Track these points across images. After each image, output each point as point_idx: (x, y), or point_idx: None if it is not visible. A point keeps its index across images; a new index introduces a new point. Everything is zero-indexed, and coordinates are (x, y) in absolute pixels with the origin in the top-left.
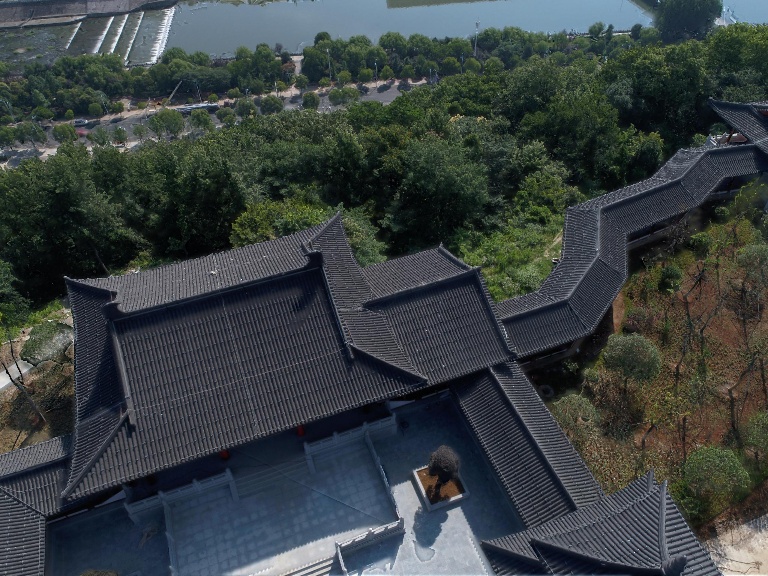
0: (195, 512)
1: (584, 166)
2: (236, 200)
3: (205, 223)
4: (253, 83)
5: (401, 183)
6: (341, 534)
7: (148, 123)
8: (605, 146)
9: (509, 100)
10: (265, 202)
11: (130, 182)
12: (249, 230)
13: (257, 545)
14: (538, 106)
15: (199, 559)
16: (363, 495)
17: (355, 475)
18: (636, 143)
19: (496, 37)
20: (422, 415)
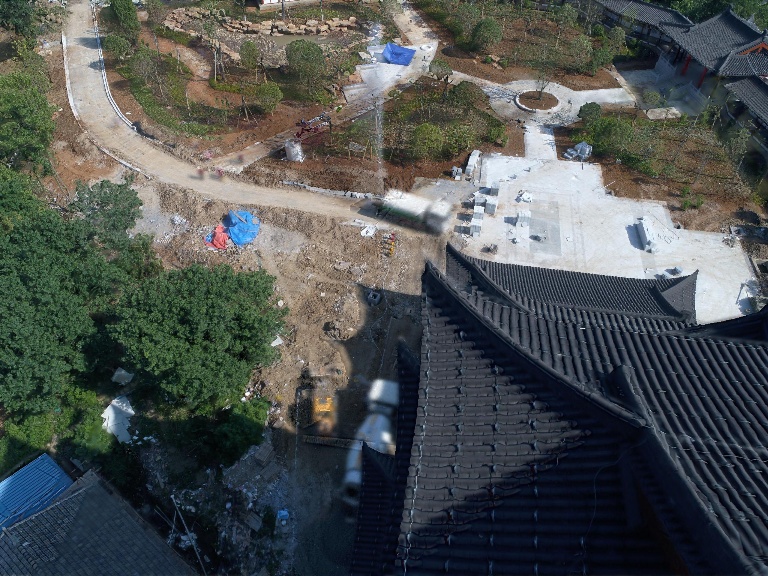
0: None
1: None
2: None
3: None
4: None
5: None
6: None
7: None
8: None
9: None
10: None
11: None
12: None
13: None
14: None
15: None
16: None
17: None
18: None
19: None
20: None
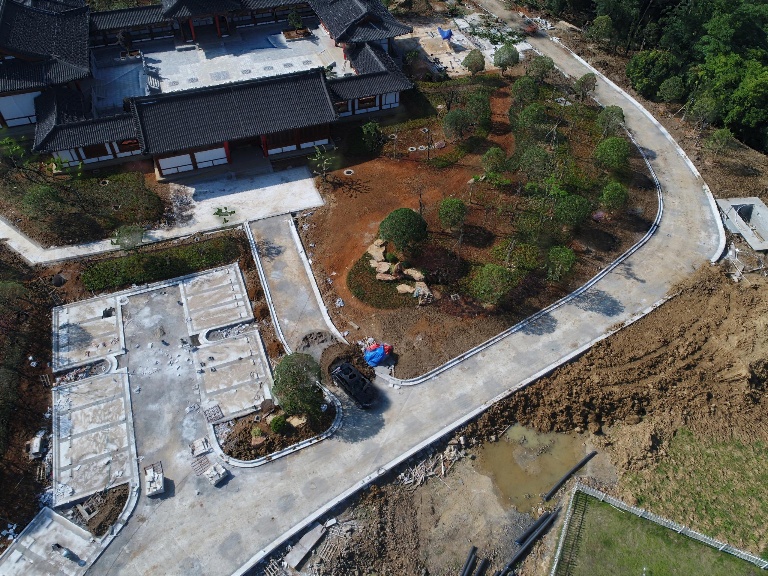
0: None
1: None
2: None
3: None
4: None
5: None
6: None
7: None
8: None
9: None
10: None
11: None
12: None
13: None
14: None
15: None
16: (125, 69)
17: (114, 71)
18: None
19: None
20: None
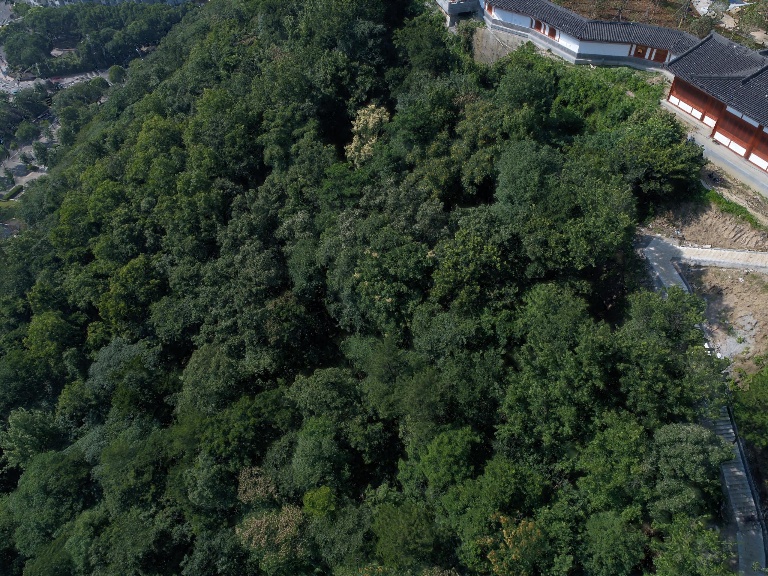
0: None
1: None
2: None
3: None
4: None
5: None
6: None
7: None
8: (408, 61)
9: None
10: None
11: None
12: (675, 161)
13: None
14: None
15: None
16: None
17: None
18: None
19: None
20: None
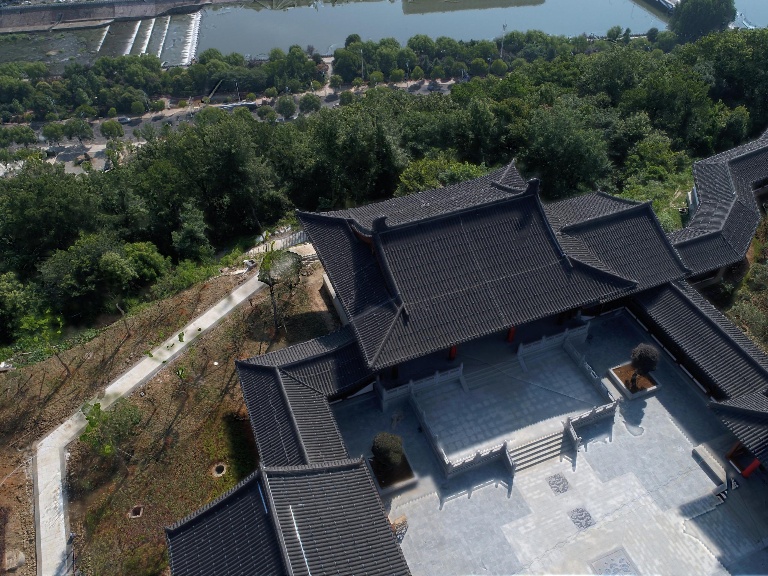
0: (435, 400)
1: (678, 137)
2: (384, 162)
3: (356, 183)
4: (290, 82)
5: (519, 150)
6: (564, 415)
7: (194, 119)
8: (691, 121)
9: (590, 83)
10: (423, 159)
11: (277, 149)
12: (415, 182)
13: (496, 424)
14: (617, 89)
15: (451, 434)
16: (574, 387)
17: (562, 372)
18: (723, 117)
19: (520, 40)
20: (601, 329)
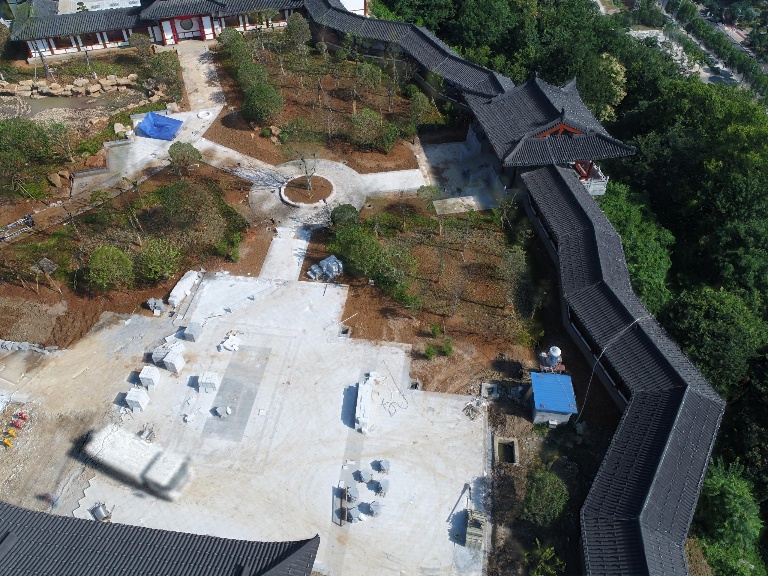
0: None
1: None
2: None
3: None
4: None
5: None
6: None
7: None
8: None
9: None
10: None
11: None
12: None
13: None
14: None
15: None
16: None
17: None
18: None
19: None
20: None
